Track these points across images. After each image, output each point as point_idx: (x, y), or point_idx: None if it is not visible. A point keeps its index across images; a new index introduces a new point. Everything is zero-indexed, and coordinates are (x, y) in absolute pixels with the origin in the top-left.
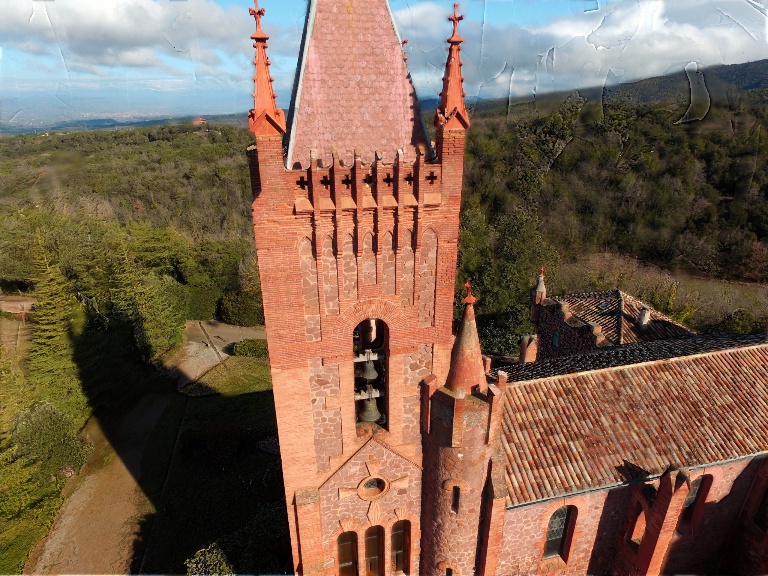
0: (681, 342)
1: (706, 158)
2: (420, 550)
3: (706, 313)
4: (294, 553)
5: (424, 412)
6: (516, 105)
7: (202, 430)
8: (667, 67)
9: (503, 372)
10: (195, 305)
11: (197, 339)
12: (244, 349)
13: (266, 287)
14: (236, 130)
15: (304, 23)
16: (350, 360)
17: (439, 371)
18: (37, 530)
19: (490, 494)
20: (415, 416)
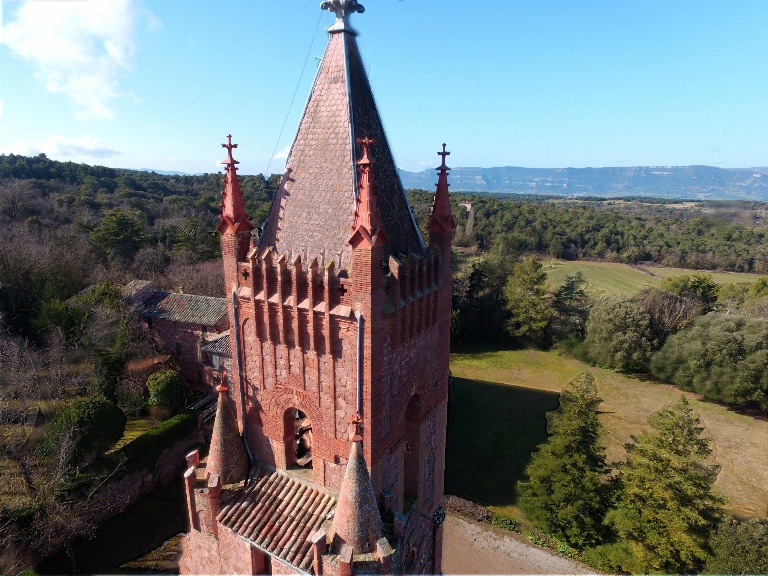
0: None
1: None
2: None
3: None
4: None
5: None
6: None
7: None
8: None
9: (189, 473)
10: None
11: None
12: None
13: None
14: None
15: None
16: None
17: None
18: (640, 568)
19: None
20: None
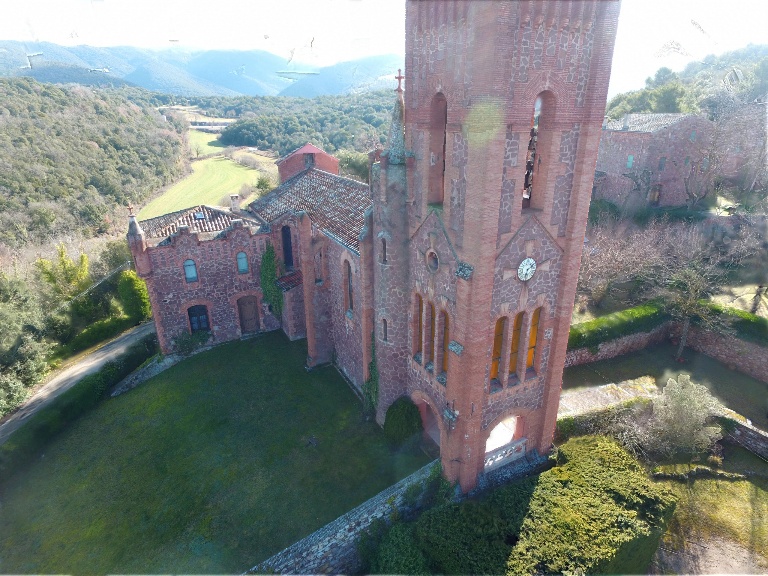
0: (283, 200)
1: None
2: None
3: None
4: None
5: None
6: None
7: None
8: None
9: None
10: None
11: None
12: None
13: None
14: None
15: None
16: None
17: None
18: None
19: None
20: None
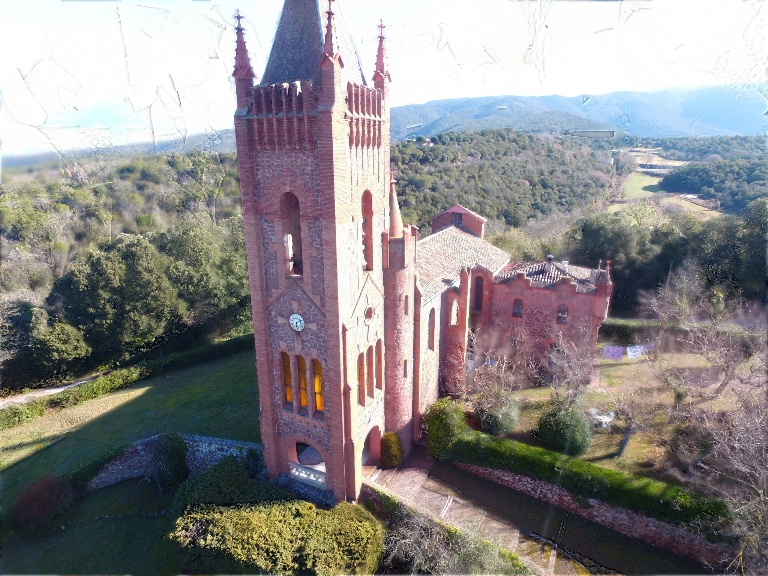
0: None
1: None
2: (385, 363)
3: None
4: (342, 378)
5: (384, 255)
6: (160, 136)
7: None
8: None
9: None
10: None
11: None
12: None
13: (335, 164)
14: None
15: (282, 12)
16: None
17: None
18: None
19: (418, 297)
20: (380, 259)
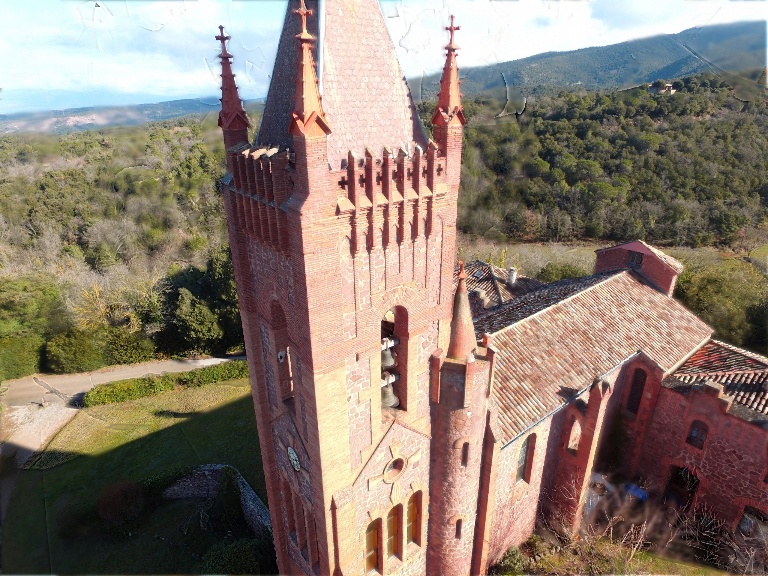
0: (547, 291)
1: (501, 145)
2: (428, 515)
3: (526, 270)
4: (330, 560)
5: (433, 385)
6: None
7: (85, 501)
8: (468, 70)
9: None
10: (6, 361)
11: (22, 401)
12: (100, 397)
13: (311, 292)
14: (13, 139)
15: None
16: (379, 350)
17: (443, 344)
18: None
19: (490, 441)
20: (425, 391)
